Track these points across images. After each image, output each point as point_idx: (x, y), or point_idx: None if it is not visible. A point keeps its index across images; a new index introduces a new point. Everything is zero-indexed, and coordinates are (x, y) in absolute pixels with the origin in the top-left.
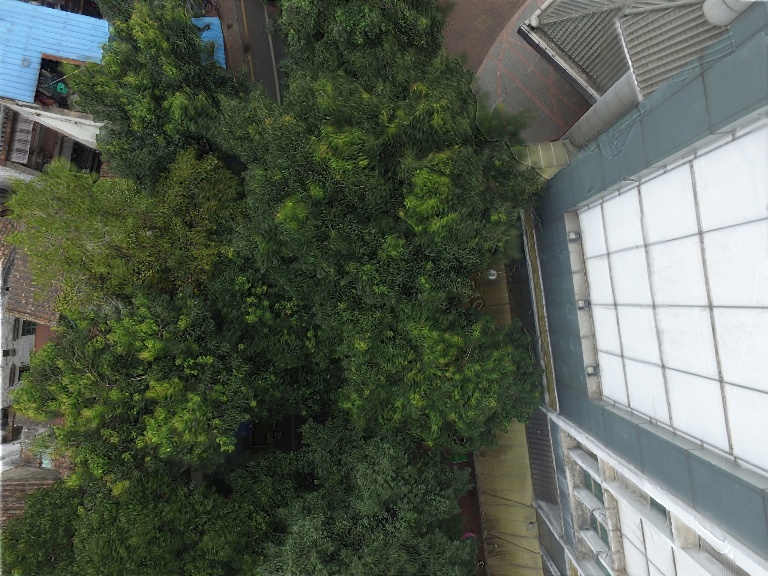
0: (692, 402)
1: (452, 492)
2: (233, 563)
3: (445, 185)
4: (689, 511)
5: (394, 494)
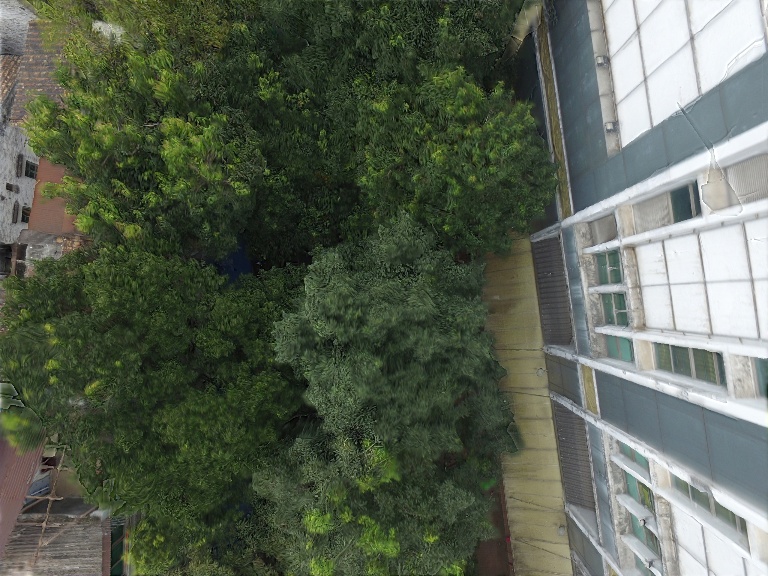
0: (725, 37)
1: (468, 267)
2: (245, 348)
3: None
4: (722, 143)
5: (411, 252)
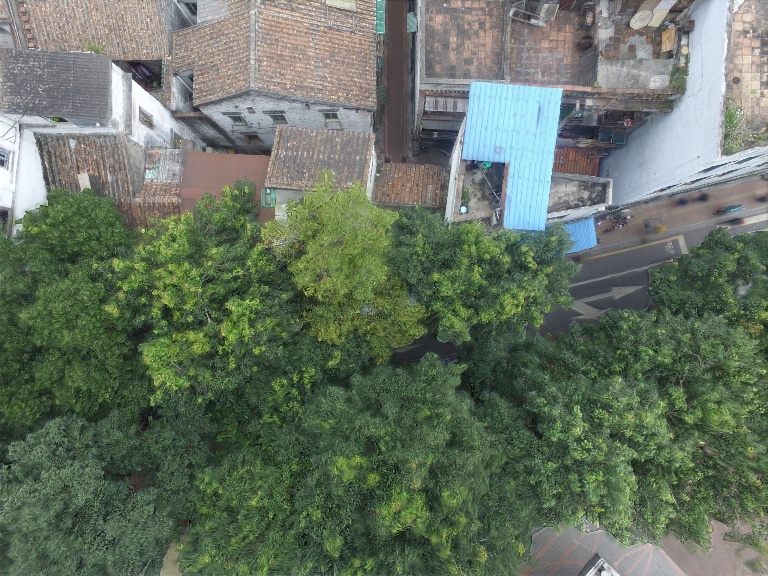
0: None
1: None
2: None
3: None
4: None
5: None
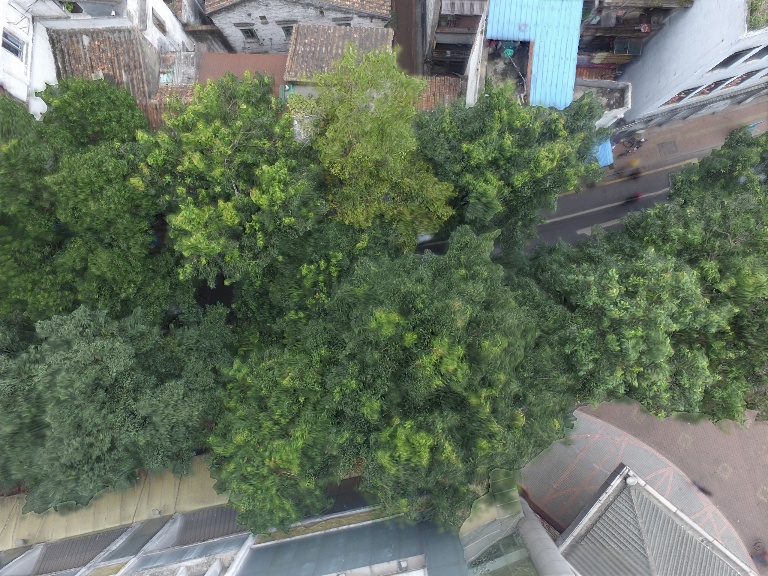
0: None
1: None
2: (88, 273)
3: (430, 457)
4: None
5: None
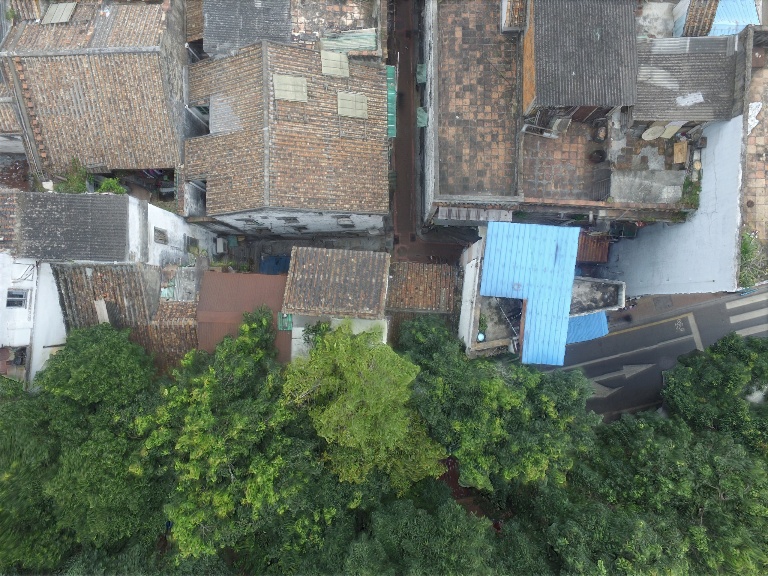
0: None
1: None
2: None
3: None
4: None
5: None
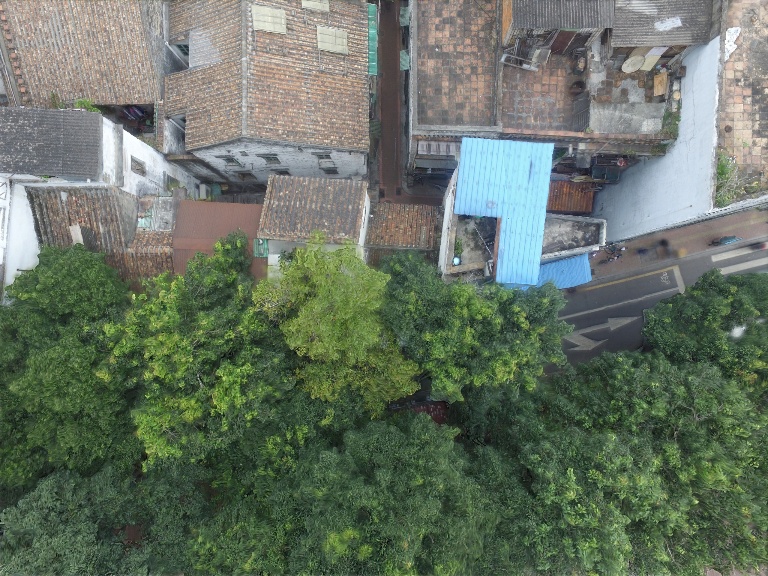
0: None
1: None
2: None
3: None
4: None
5: None
